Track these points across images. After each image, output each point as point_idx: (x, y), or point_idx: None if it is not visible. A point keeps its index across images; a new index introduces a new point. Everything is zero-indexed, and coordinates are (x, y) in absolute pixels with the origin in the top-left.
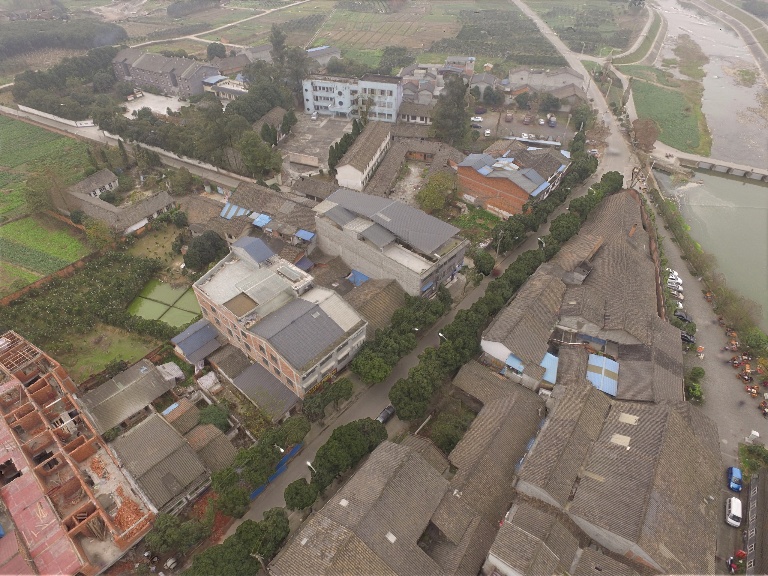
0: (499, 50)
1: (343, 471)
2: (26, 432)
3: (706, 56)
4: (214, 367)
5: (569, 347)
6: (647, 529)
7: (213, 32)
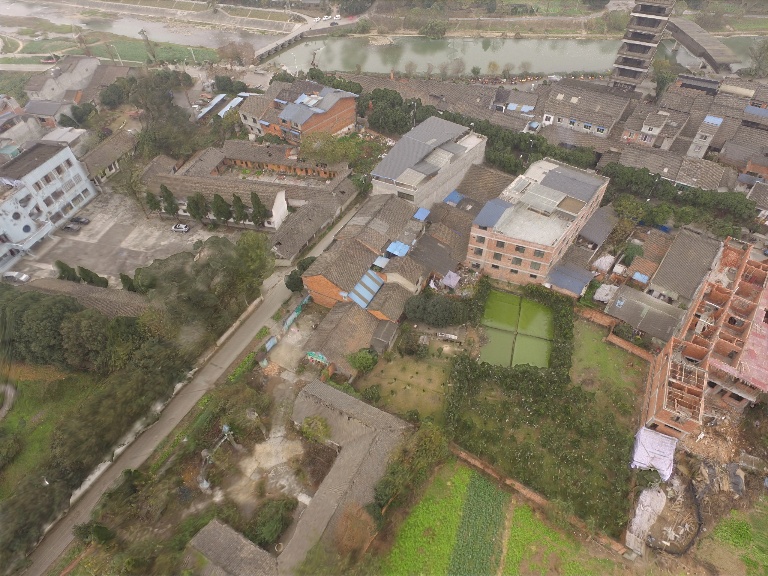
0: None
1: None
2: None
3: (30, 17)
4: None
5: None
6: None
7: None
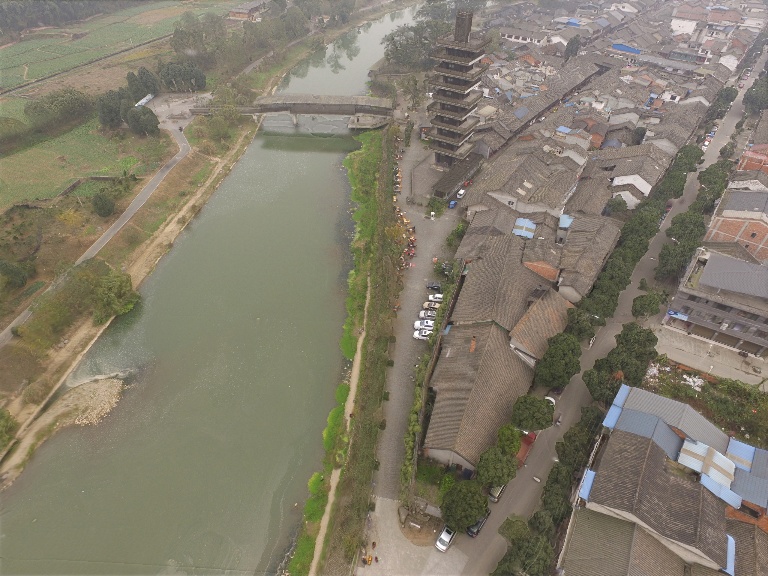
0: None
1: None
2: None
3: None
4: None
5: None
6: None
7: None
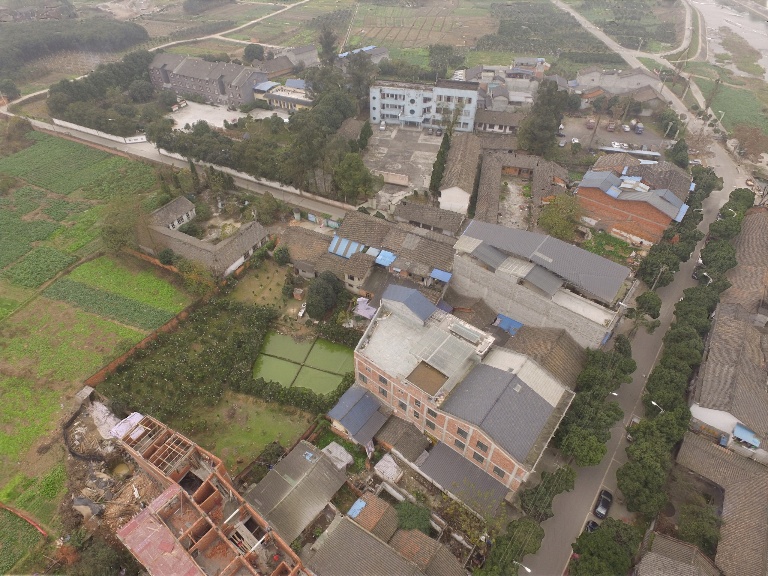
0: (549, 47)
1: None
2: (201, 553)
3: (757, 50)
4: (382, 445)
5: None
6: None
7: (238, 30)
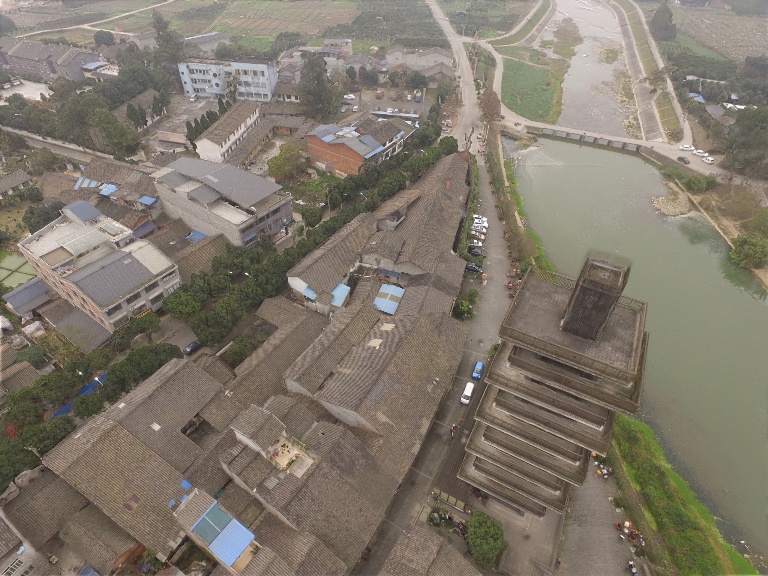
0: (389, 34)
1: (134, 386)
2: None
3: (581, 37)
4: (44, 318)
5: (366, 280)
6: (368, 401)
7: (109, 21)
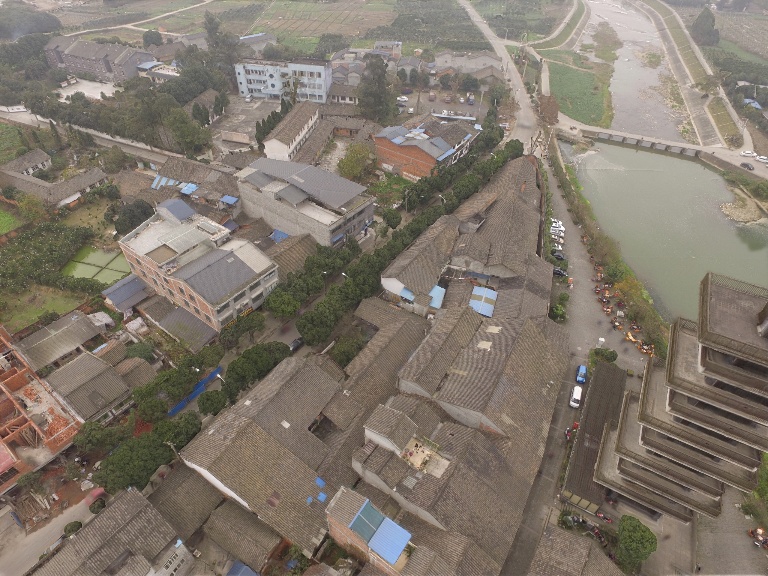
0: (430, 36)
1: (251, 383)
2: None
3: (620, 41)
4: (142, 315)
5: (458, 282)
6: (493, 403)
7: (151, 21)
